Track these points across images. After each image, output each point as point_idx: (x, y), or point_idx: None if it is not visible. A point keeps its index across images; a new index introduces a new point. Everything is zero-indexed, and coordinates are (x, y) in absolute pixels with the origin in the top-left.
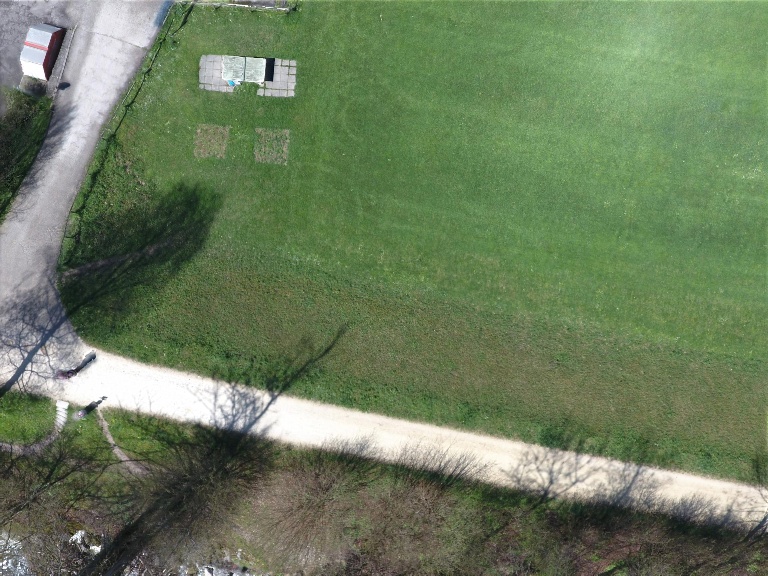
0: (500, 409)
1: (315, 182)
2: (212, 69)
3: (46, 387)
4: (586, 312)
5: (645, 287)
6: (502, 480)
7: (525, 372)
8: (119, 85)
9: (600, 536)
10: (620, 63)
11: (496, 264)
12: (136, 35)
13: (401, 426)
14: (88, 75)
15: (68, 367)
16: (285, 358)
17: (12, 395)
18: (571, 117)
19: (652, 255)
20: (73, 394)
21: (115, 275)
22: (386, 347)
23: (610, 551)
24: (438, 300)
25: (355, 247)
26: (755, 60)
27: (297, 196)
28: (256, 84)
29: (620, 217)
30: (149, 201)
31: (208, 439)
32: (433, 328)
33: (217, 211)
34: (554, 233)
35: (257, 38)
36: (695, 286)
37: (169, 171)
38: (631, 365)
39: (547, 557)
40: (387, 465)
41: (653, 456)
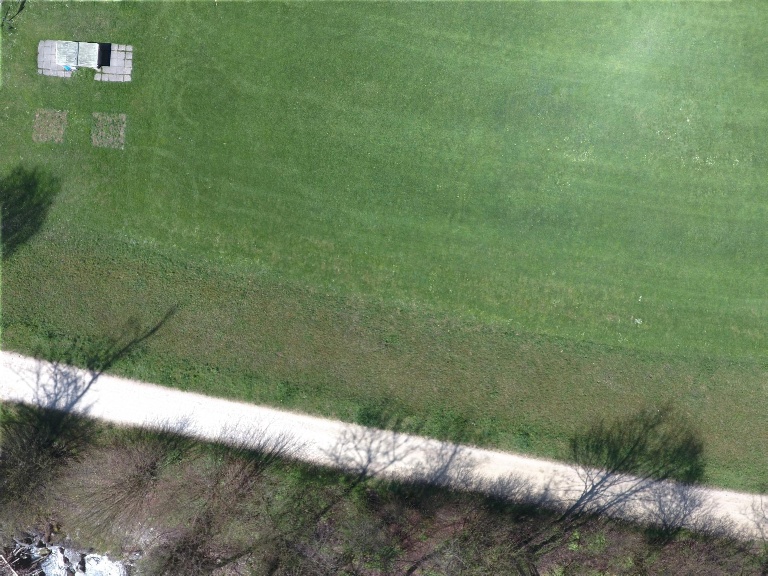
0: (319, 388)
1: (152, 166)
2: (50, 54)
3: None
4: (420, 294)
5: (478, 269)
6: (321, 458)
7: (352, 353)
8: None
9: (422, 515)
10: (452, 47)
11: (331, 247)
12: None
13: (219, 405)
14: None
15: None
16: (109, 338)
17: None
18: (404, 101)
19: (484, 237)
20: None
21: None
22: (213, 328)
23: (436, 530)
24: (272, 282)
25: (191, 230)
26: (585, 43)
27: (134, 180)
28: (92, 69)
29: (452, 200)
30: None
31: (32, 417)
32: (264, 309)
33: (55, 195)
34: (388, 216)
35: (93, 23)
36: (527, 268)
37: (8, 155)
38: (460, 346)
39: (378, 536)
40: (207, 443)
41: (470, 435)
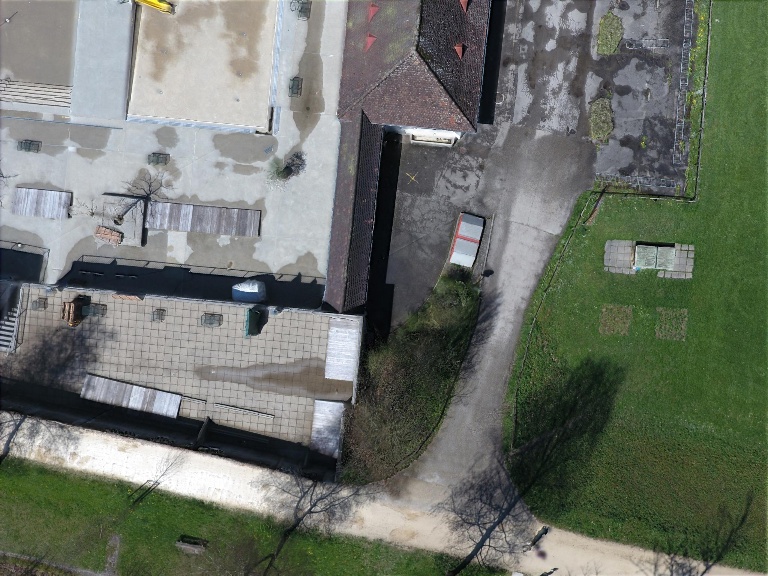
0: None
1: (710, 356)
2: (616, 253)
3: (502, 560)
4: None
5: None
6: None
7: None
8: (537, 271)
9: None
10: None
11: None
12: (549, 223)
13: None
14: (509, 262)
15: (523, 542)
16: (712, 529)
17: (472, 568)
18: None
19: None
20: (527, 566)
21: (548, 451)
22: None
23: None
24: None
25: (745, 415)
26: None
27: (693, 369)
28: None
29: None
30: (561, 376)
31: None
32: None
33: (620, 383)
34: None
35: (659, 225)
36: None
37: (577, 347)
38: None
39: None
40: None
41: None
